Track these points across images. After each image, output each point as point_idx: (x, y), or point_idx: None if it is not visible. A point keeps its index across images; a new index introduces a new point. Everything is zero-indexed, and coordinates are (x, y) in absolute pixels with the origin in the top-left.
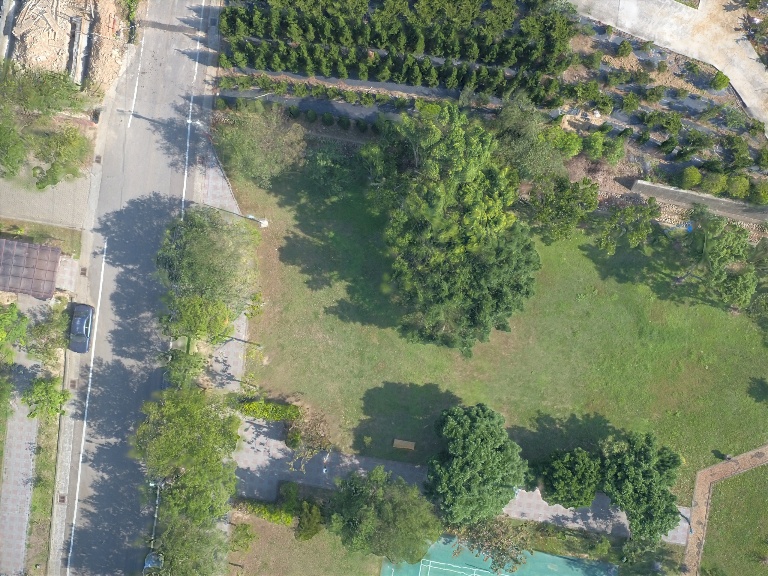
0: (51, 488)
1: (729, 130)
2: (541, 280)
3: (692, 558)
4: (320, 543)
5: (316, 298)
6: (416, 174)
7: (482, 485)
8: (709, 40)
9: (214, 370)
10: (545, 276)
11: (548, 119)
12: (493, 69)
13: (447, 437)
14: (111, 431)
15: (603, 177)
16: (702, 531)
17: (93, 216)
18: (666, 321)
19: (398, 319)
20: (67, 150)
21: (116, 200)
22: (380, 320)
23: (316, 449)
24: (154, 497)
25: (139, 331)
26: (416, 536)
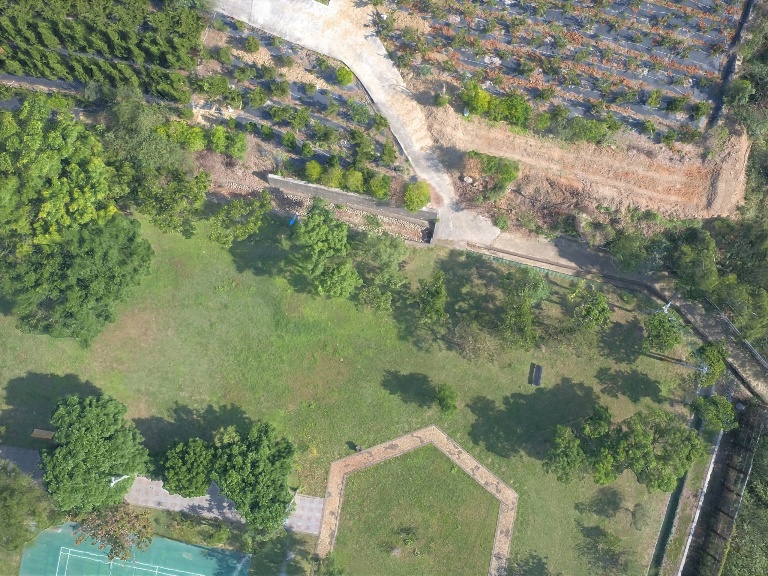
0: None
1: (358, 125)
2: (180, 273)
3: (324, 548)
4: None
5: None
6: None
7: (87, 474)
8: (338, 36)
9: None
10: (184, 269)
11: (176, 113)
12: (116, 64)
13: (54, 426)
14: None
15: (242, 171)
16: (335, 521)
17: None
18: (303, 314)
19: None
20: None
21: None
22: None
23: None
24: None
25: None
26: (7, 523)
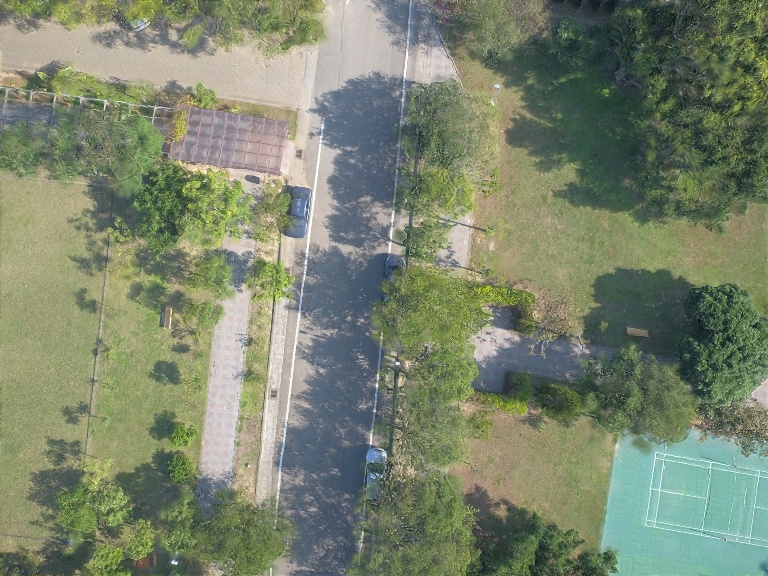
0: (263, 382)
1: None
2: None
3: None
4: (550, 437)
5: (544, 182)
6: (672, 41)
7: (742, 362)
8: None
9: (437, 256)
10: None
11: None
12: None
13: (705, 313)
14: (327, 321)
15: None
16: None
17: (309, 96)
18: None
19: (629, 203)
20: (304, 15)
21: (334, 79)
22: (611, 204)
23: (556, 333)
24: (373, 391)
25: (358, 216)
26: (687, 410)
